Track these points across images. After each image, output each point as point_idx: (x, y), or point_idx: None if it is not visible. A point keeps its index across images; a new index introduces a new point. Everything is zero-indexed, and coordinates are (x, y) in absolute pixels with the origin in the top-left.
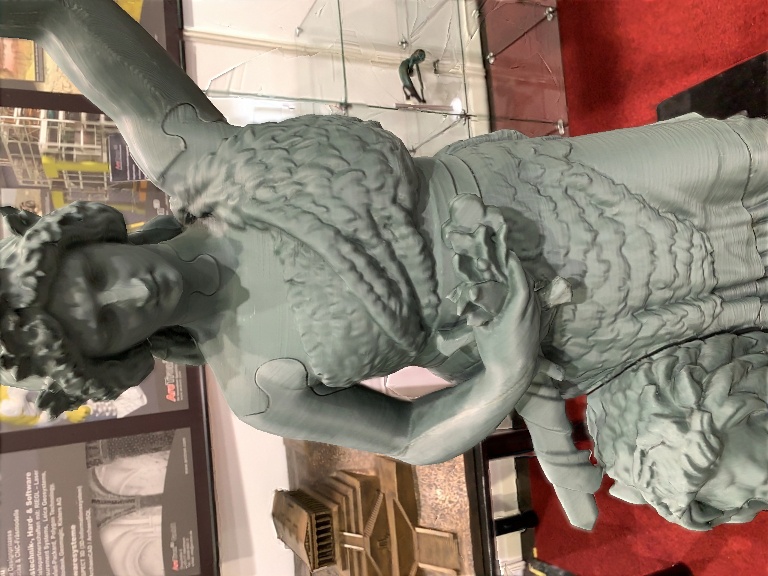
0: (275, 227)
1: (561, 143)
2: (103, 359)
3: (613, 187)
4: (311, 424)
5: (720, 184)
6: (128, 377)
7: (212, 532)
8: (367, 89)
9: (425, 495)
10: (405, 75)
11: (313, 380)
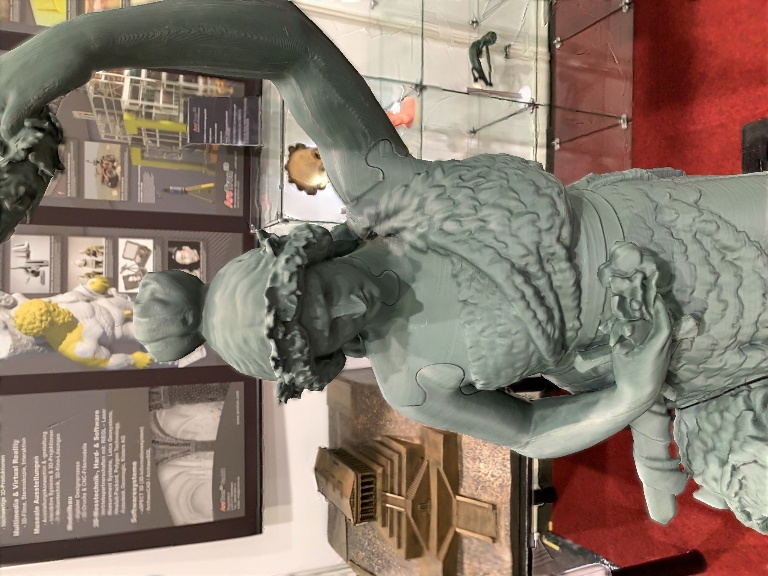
0: (457, 255)
1: (692, 189)
2: (320, 358)
3: (736, 234)
4: (456, 418)
5: None
6: (333, 373)
7: (257, 480)
8: (442, 72)
9: (468, 467)
10: (475, 57)
11: (465, 383)
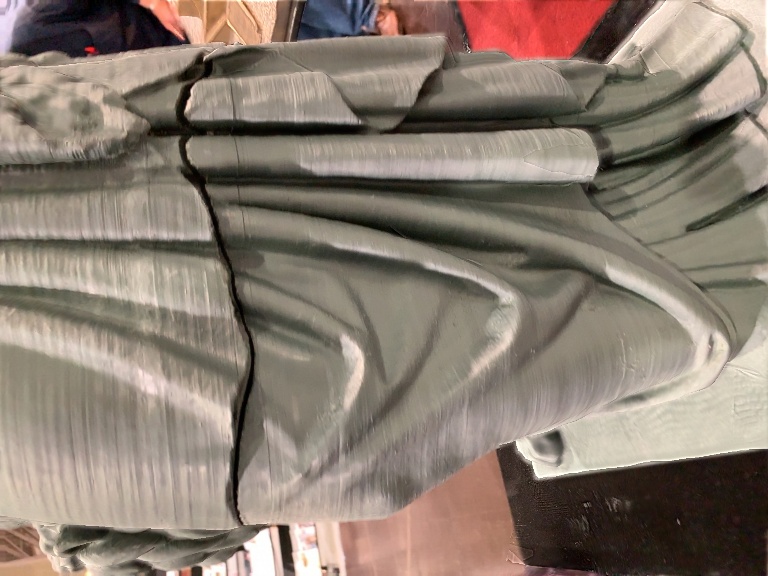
0: None
1: None
2: None
3: None
4: None
5: None
6: None
7: None
8: None
9: None
10: None
11: None
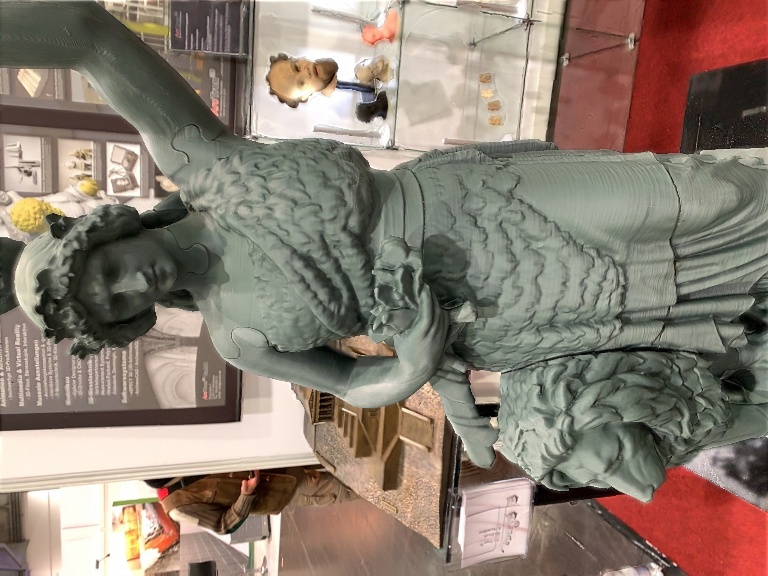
0: None
1: (510, 177)
2: (116, 323)
3: (543, 225)
4: (271, 371)
5: (646, 229)
6: (134, 334)
7: (238, 374)
8: None
9: None
10: None
11: (273, 344)
